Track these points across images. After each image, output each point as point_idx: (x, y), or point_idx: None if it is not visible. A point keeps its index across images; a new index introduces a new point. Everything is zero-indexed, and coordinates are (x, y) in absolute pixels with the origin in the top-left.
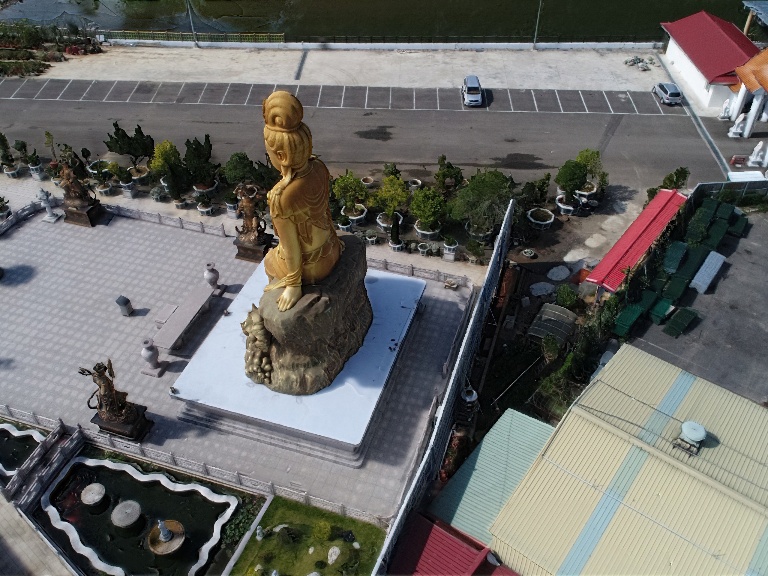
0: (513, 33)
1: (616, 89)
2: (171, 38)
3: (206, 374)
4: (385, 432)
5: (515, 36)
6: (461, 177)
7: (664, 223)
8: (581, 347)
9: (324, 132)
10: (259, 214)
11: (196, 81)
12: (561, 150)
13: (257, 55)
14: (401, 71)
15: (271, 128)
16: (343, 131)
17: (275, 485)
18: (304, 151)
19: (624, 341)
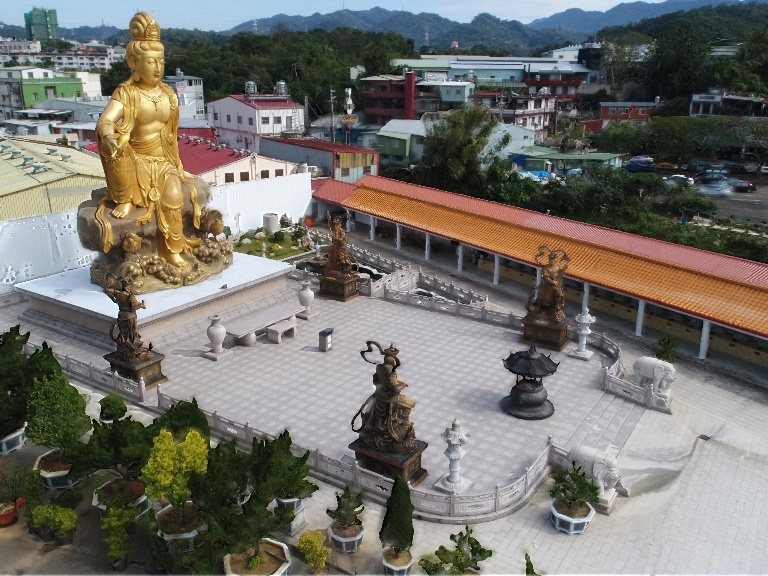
0: None
1: None
2: None
3: None
4: None
5: None
6: None
7: None
8: None
9: None
10: None
11: None
12: None
13: None
14: None
15: None
16: None
17: None
18: None
19: None
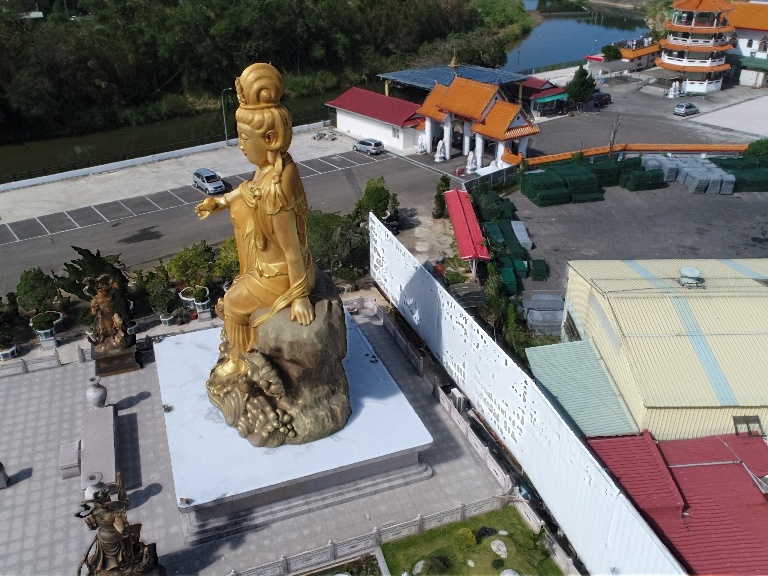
0: (204, 135)
1: (325, 155)
2: None
3: (206, 469)
4: None
5: (207, 137)
6: None
7: (471, 210)
8: None
9: None
10: (86, 331)
11: None
12: (328, 201)
13: None
14: (115, 187)
15: (255, 107)
16: (103, 244)
17: None
18: None
19: (517, 296)
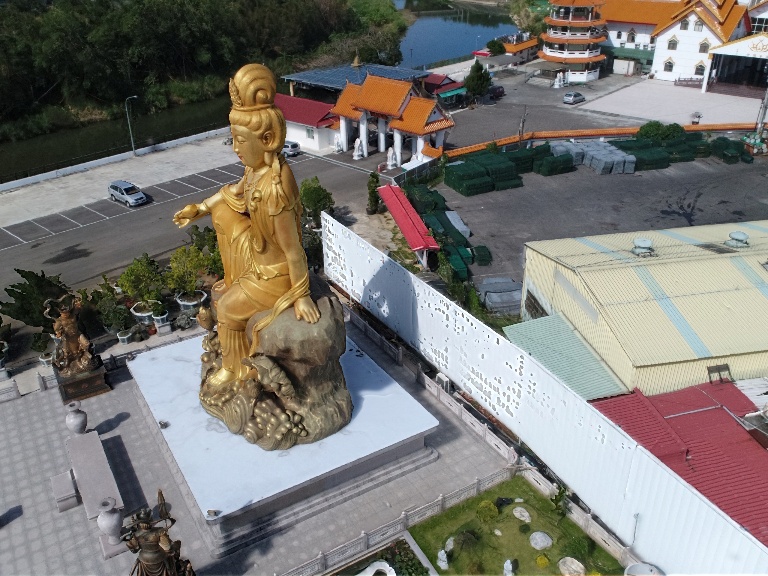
0: (110, 146)
1: None
2: None
3: (224, 479)
4: None
5: (113, 149)
6: None
7: (408, 203)
8: None
9: (4, 275)
10: (39, 358)
11: None
12: None
13: None
14: (22, 206)
15: (252, 108)
16: (27, 267)
17: None
18: None
19: None
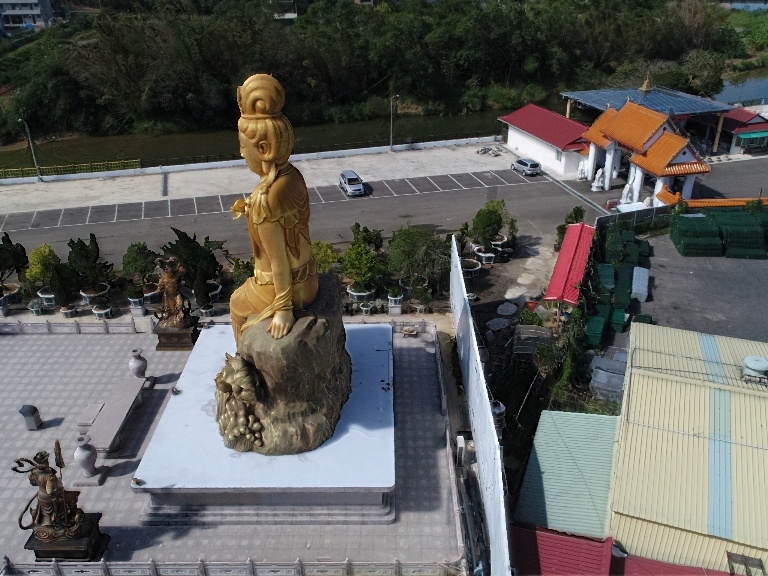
0: (370, 138)
1: (480, 170)
2: (9, 175)
3: (173, 456)
4: (405, 480)
5: (372, 141)
6: (380, 240)
7: (587, 247)
8: (569, 357)
9: (213, 233)
10: None
11: (49, 209)
12: (456, 217)
13: (113, 182)
14: None
15: (250, 116)
16: (233, 229)
17: (304, 562)
18: (289, 141)
19: (599, 351)
